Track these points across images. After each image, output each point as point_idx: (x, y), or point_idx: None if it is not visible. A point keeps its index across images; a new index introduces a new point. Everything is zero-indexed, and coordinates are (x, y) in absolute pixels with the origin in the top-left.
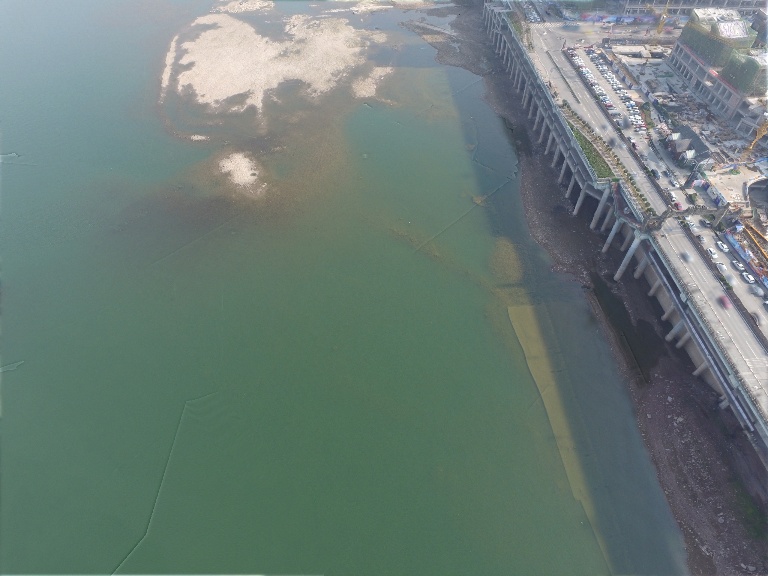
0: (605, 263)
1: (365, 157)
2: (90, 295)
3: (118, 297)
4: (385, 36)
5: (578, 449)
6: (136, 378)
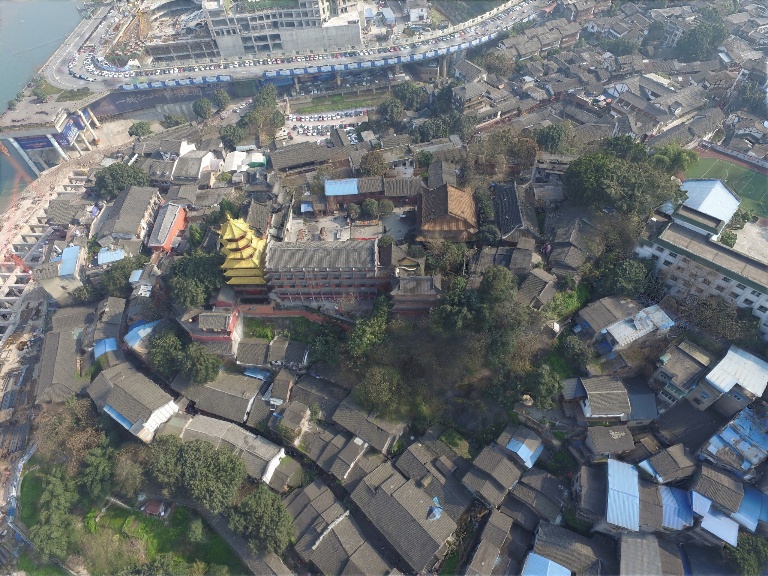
0: None
1: (21, 22)
2: None
3: None
4: None
5: None
6: None
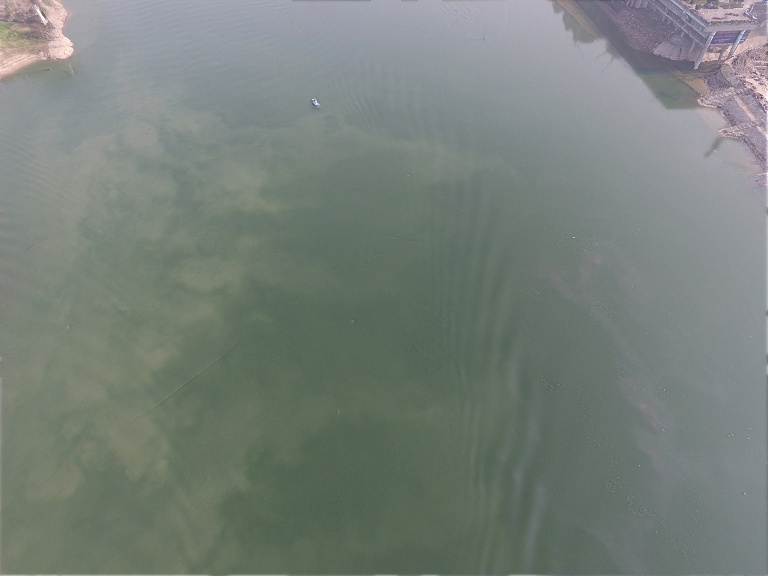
0: None
1: None
2: (354, 7)
3: (368, 8)
4: None
5: (589, 25)
6: (393, 23)
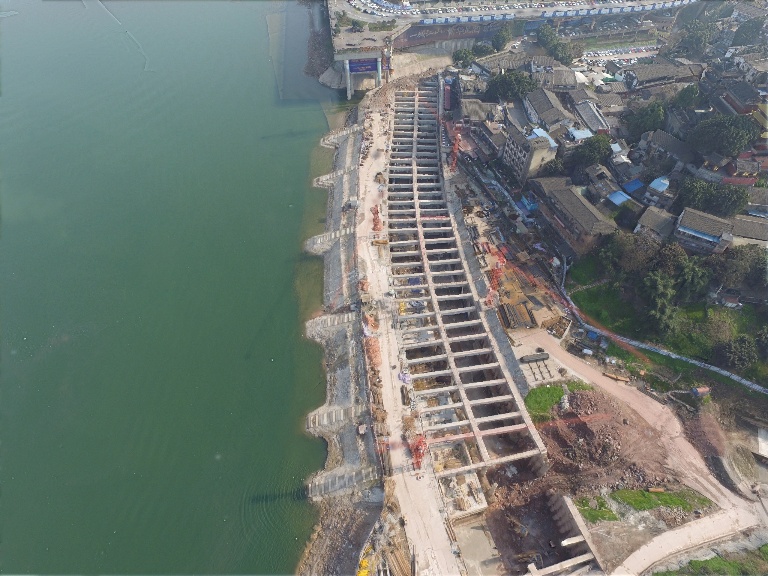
0: (323, 1)
1: None
2: (48, 25)
3: (64, 26)
4: None
5: (277, 46)
6: (75, 46)
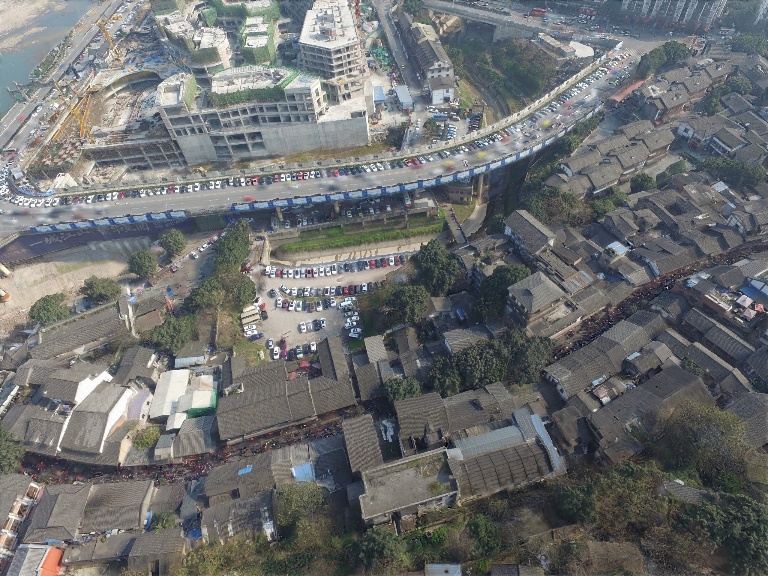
0: None
1: None
2: None
3: None
4: (66, 6)
5: None
6: None
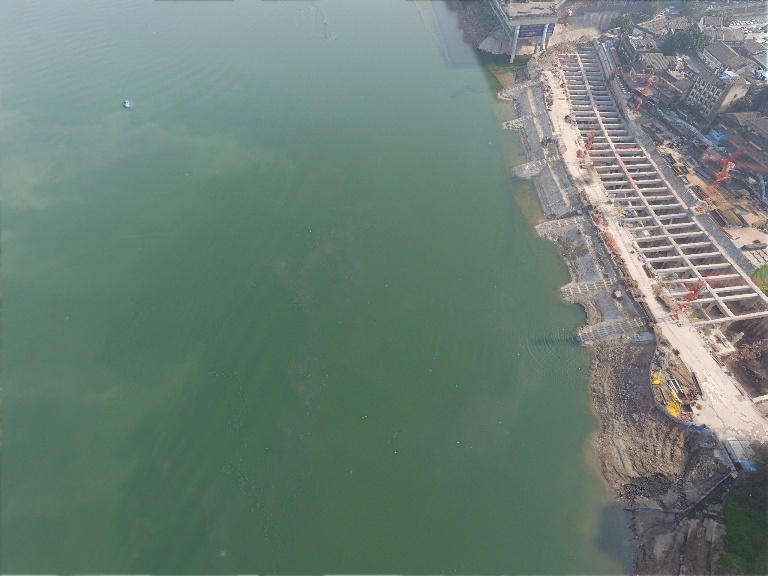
0: None
1: None
2: (218, 7)
3: (231, 8)
4: None
5: (431, 21)
6: None
